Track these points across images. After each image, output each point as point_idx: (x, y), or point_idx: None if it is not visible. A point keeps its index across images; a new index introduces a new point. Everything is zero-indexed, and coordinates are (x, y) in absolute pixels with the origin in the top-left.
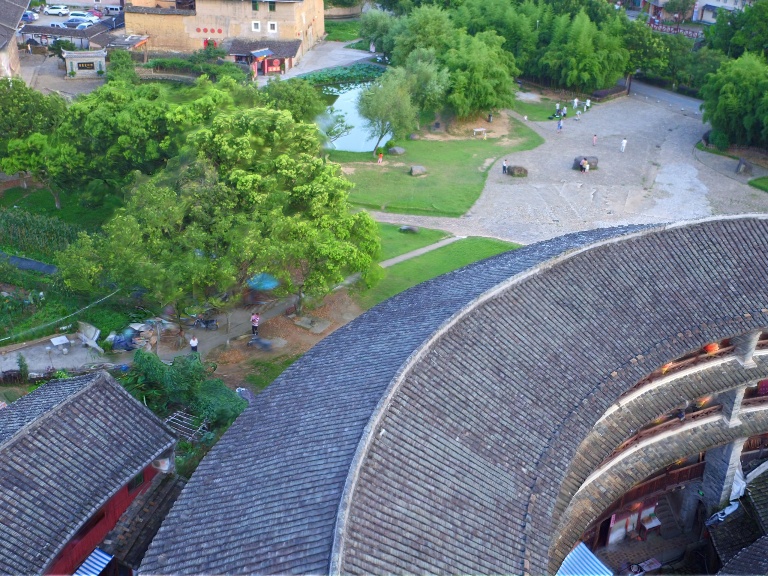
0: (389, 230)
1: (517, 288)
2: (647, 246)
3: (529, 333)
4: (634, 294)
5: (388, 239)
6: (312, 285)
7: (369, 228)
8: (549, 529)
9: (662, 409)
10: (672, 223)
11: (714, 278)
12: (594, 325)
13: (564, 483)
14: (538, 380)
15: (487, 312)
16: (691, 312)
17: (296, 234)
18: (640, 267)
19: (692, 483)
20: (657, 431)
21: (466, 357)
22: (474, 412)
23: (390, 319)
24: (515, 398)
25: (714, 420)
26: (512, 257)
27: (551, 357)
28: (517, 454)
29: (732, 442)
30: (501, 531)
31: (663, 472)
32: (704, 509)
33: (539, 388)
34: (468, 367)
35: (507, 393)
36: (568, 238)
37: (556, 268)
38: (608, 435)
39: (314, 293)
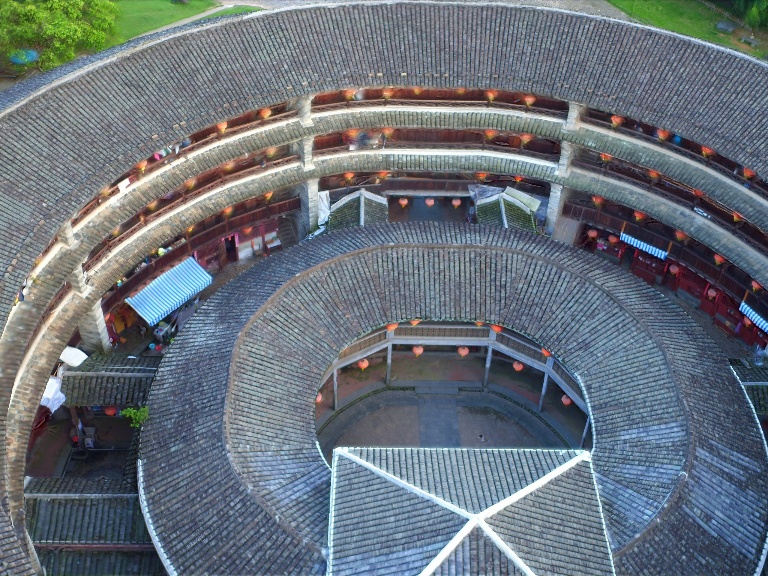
0: (162, 1)
1: (93, 74)
2: (223, 34)
3: (91, 108)
4: (198, 74)
5: (157, 10)
6: (45, 61)
7: (101, 7)
8: (47, 241)
9: (223, 160)
10: (249, 14)
11: (273, 59)
12: (153, 100)
13: (118, 214)
14: (85, 143)
15: (58, 94)
16: (243, 87)
17: (26, 16)
18: (211, 52)
19: (297, 213)
20: (242, 176)
21: (26, 128)
22: (18, 167)
23: (1, 99)
24: (59, 156)
25: (294, 166)
26: (127, 44)
27: (104, 126)
28: (43, 194)
29: (305, 182)
30: (4, 243)
31: (263, 206)
32: (306, 232)
33: (84, 149)
34: (25, 135)
35: (53, 153)
36: (190, 25)
37: (134, 56)
38: (170, 180)
39: (49, 67)
